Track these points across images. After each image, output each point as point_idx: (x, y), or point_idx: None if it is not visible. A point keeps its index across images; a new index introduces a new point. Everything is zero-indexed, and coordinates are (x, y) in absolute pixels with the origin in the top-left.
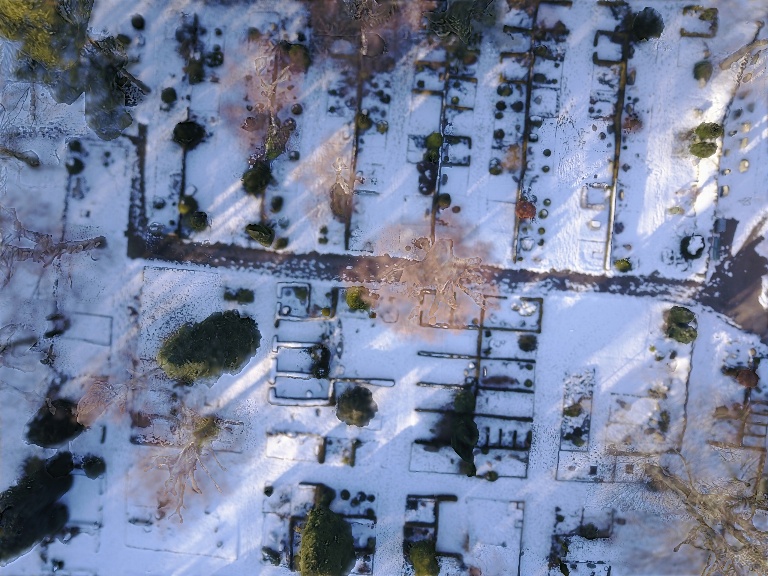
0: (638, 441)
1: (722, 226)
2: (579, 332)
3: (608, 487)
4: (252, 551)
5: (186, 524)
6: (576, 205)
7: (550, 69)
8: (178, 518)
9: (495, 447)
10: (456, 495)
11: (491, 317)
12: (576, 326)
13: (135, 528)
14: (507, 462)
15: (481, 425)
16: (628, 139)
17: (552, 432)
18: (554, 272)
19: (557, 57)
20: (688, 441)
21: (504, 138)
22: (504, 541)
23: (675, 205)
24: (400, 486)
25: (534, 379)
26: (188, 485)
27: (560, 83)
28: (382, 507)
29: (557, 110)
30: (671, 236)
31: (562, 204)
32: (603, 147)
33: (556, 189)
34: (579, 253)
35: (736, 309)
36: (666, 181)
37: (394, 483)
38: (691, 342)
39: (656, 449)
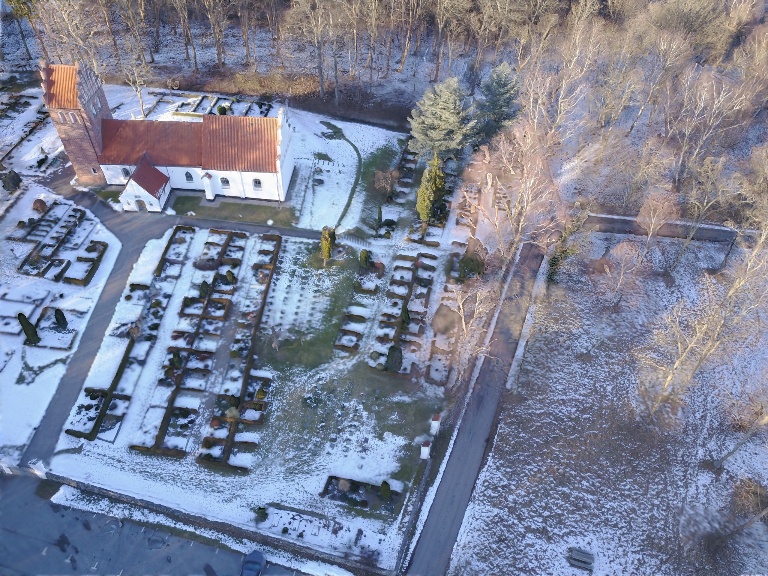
0: None
1: (60, 153)
2: None
3: None
4: None
5: None
6: None
7: None
8: None
9: None
10: None
11: None
12: None
13: None
14: None
15: None
16: (37, 133)
17: None
18: None
19: (21, 111)
20: None
21: None
22: None
23: None
24: None
25: None
26: None
27: (16, 118)
28: None
29: (8, 125)
30: None
31: None
32: (23, 135)
33: None
34: None
35: (56, 186)
36: (47, 145)
37: None
38: (19, 194)
39: None
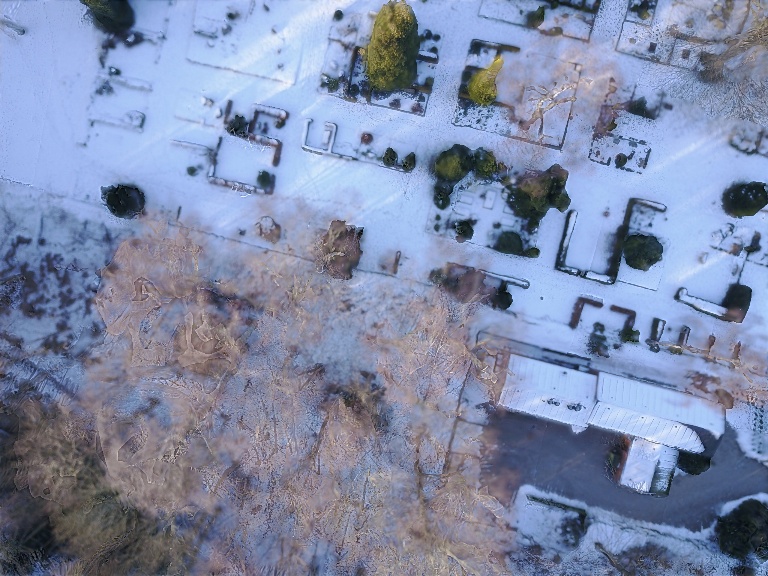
0: (699, 26)
1: None
2: None
3: (663, 69)
4: (311, 77)
5: (251, 41)
6: None
7: None
8: (243, 35)
9: (565, 3)
10: (519, 47)
11: None
12: None
13: (199, 42)
14: (573, 21)
15: None
16: None
17: (620, 2)
18: None
19: None
20: None
21: None
22: (557, 98)
23: None
24: (466, 30)
25: None
26: (259, 2)
27: None
28: (445, 49)
29: None
30: None
31: None
32: None
33: None
34: None
35: None
36: None
37: (461, 27)
38: None
39: (715, 37)
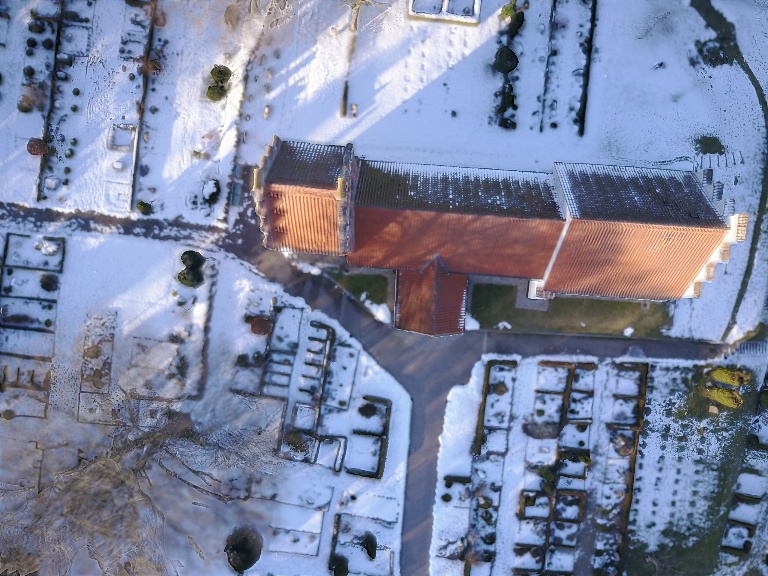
0: (160, 386)
1: (237, 171)
2: (102, 274)
3: (133, 431)
4: None
5: None
6: (103, 146)
7: (83, 7)
8: None
9: (12, 386)
10: None
11: (13, 255)
12: (99, 268)
13: None
14: (26, 401)
15: (1, 363)
16: (157, 81)
17: (73, 373)
18: (79, 212)
19: None
20: (212, 388)
21: (34, 75)
22: (22, 480)
23: (202, 150)
24: None
25: (55, 319)
26: None
27: (92, 22)
28: None
29: (87, 49)
30: (197, 181)
31: (89, 144)
32: (132, 88)
33: (84, 129)
34: (105, 194)
35: (259, 257)
36: (193, 125)
37: None
38: (209, 288)
39: (178, 395)
